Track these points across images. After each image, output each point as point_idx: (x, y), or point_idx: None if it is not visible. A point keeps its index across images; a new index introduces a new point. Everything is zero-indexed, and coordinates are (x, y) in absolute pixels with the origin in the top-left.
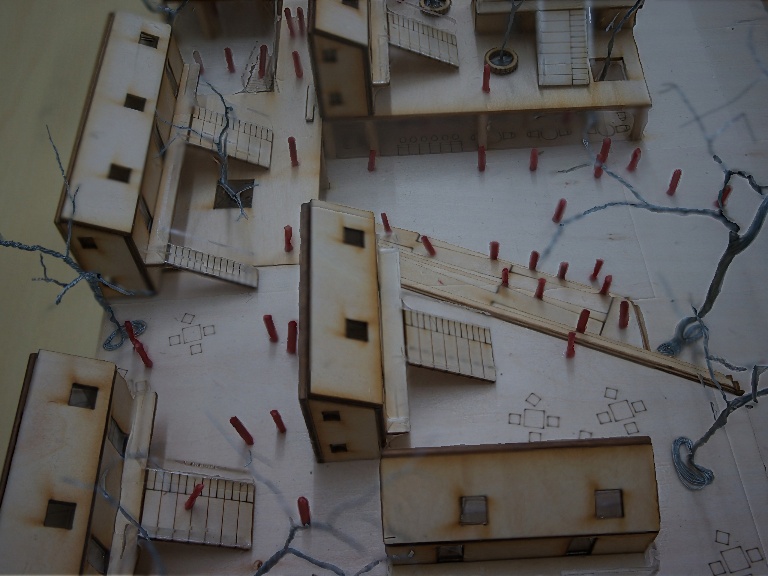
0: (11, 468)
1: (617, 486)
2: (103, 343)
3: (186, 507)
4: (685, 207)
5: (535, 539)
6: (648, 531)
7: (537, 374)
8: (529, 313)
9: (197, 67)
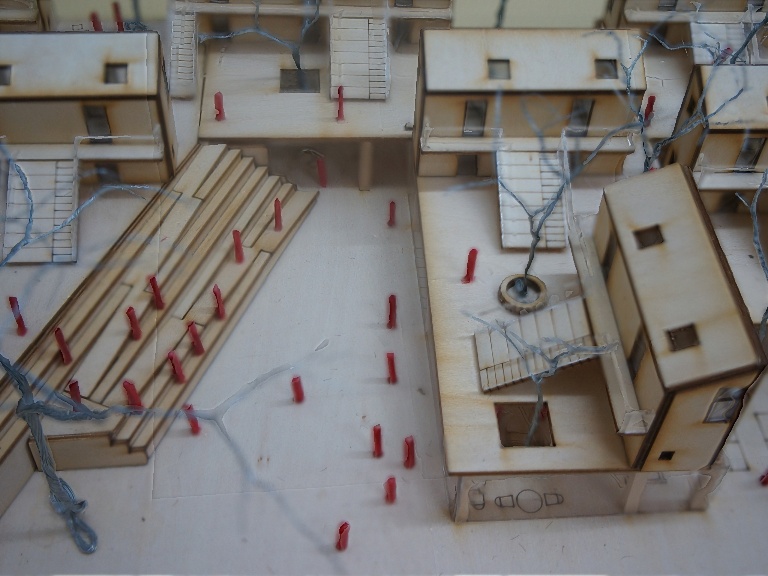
0: None
1: None
2: (134, 21)
3: None
4: (312, 563)
5: None
6: None
7: (6, 301)
8: (111, 320)
9: (444, 16)
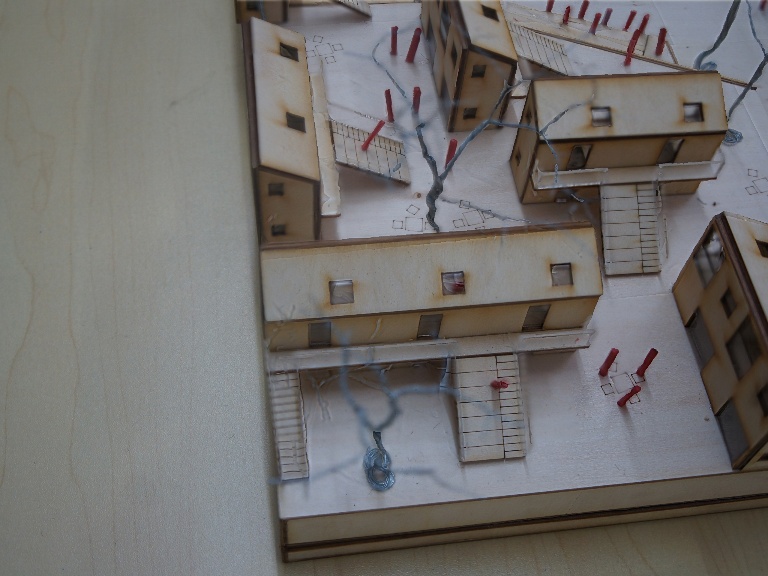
0: (256, 88)
1: (698, 100)
2: None
3: (363, 148)
4: None
5: (643, 138)
6: (720, 131)
7: None
8: None
9: None
